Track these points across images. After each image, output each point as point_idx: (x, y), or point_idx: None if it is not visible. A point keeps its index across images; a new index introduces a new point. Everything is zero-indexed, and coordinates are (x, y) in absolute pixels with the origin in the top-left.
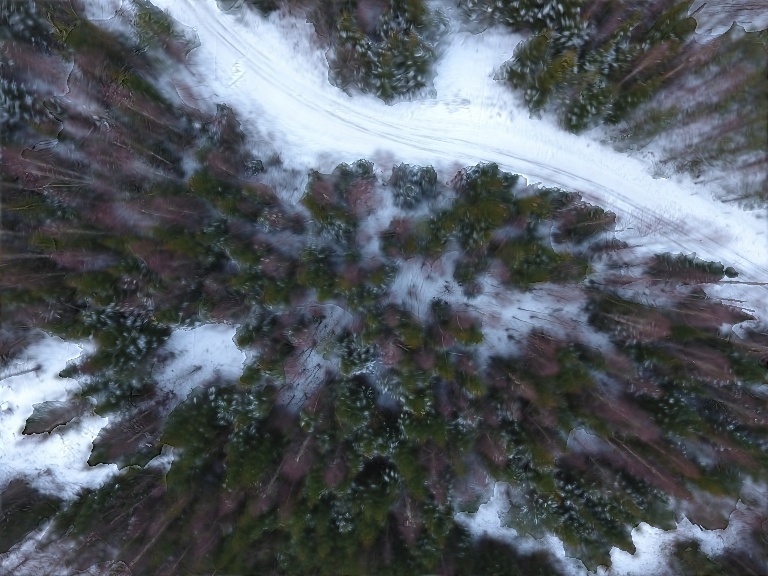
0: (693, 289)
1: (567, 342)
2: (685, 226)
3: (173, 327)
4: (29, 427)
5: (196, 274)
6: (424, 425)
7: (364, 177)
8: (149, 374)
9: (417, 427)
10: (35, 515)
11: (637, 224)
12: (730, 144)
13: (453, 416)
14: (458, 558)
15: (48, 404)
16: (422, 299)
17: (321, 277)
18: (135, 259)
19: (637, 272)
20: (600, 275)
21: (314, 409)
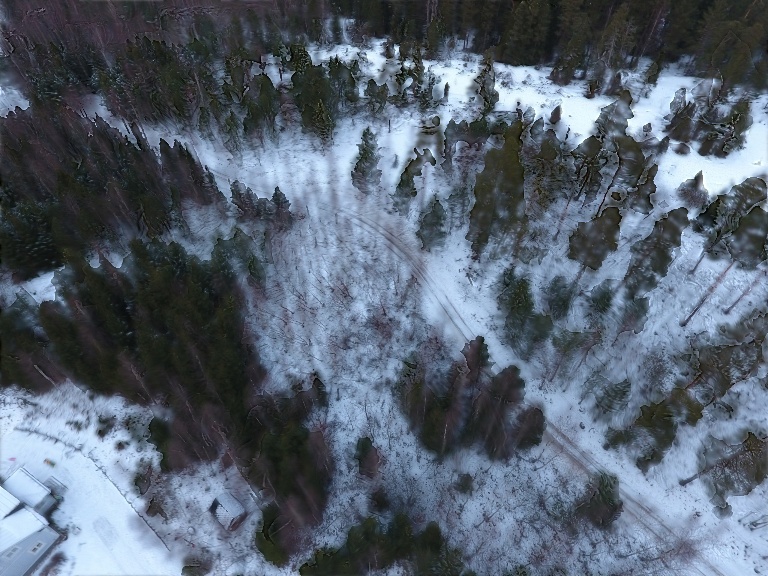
0: None
1: None
2: None
3: None
4: None
5: None
6: None
7: None
8: None
9: None
10: None
11: None
12: None
13: None
14: None
15: None
16: None
17: None
18: None
19: None
20: None
21: None
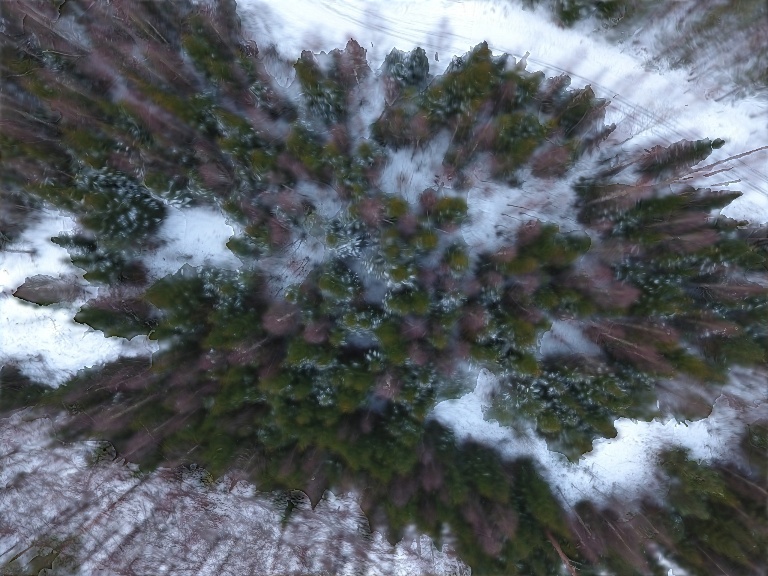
0: (684, 188)
1: (553, 223)
2: (677, 125)
3: (163, 197)
4: (20, 290)
5: (188, 147)
6: (407, 299)
7: (356, 61)
8: (139, 247)
9: (400, 300)
10: (24, 394)
11: (629, 122)
12: (720, 19)
13: (437, 297)
14: (440, 450)
15: (40, 277)
16: (411, 192)
17: (309, 145)
18: (128, 124)
19: (628, 170)
20: (590, 172)
21: (299, 286)
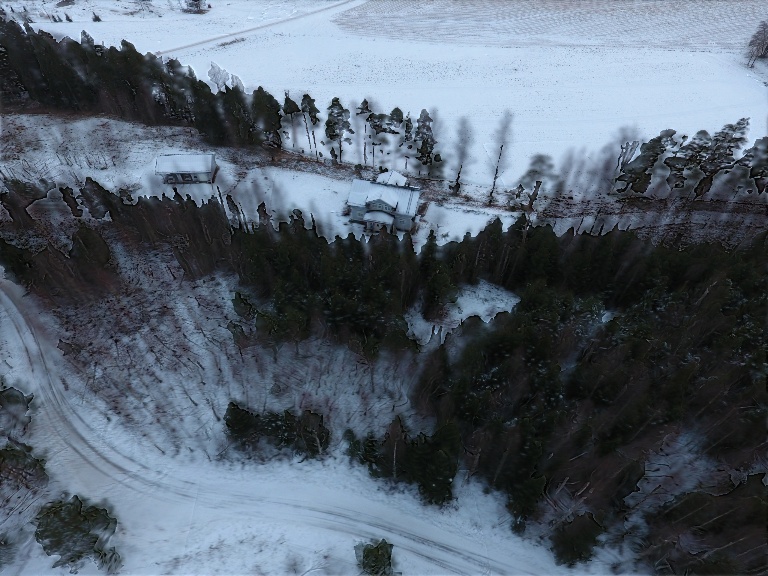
0: None
1: None
2: None
3: None
4: None
5: None
6: None
7: None
8: None
9: None
10: None
11: None
12: None
13: None
14: (611, 283)
15: None
16: (763, 468)
17: None
18: None
19: None
20: None
21: None
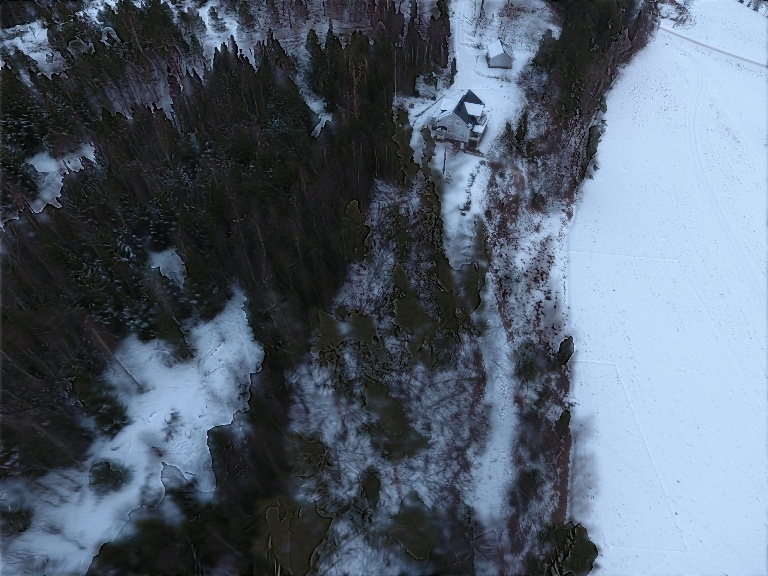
0: None
1: None
2: None
3: (120, 245)
4: None
5: None
6: None
7: None
8: None
9: None
10: None
11: None
12: None
13: None
14: None
15: None
16: None
17: None
18: None
19: None
20: (179, 129)
21: None
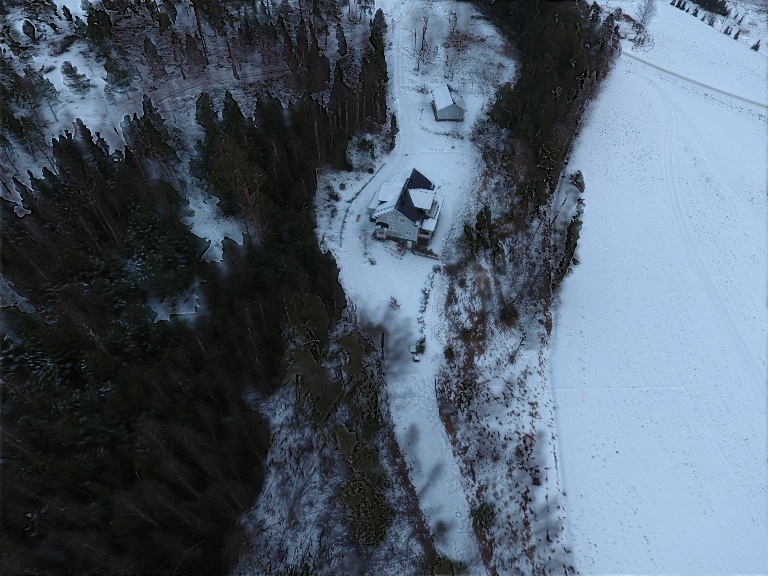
0: None
1: None
2: None
3: None
4: None
5: None
6: None
7: None
8: None
9: None
10: None
11: None
12: None
13: None
14: None
15: None
16: None
17: None
18: None
19: None
20: None
21: None
